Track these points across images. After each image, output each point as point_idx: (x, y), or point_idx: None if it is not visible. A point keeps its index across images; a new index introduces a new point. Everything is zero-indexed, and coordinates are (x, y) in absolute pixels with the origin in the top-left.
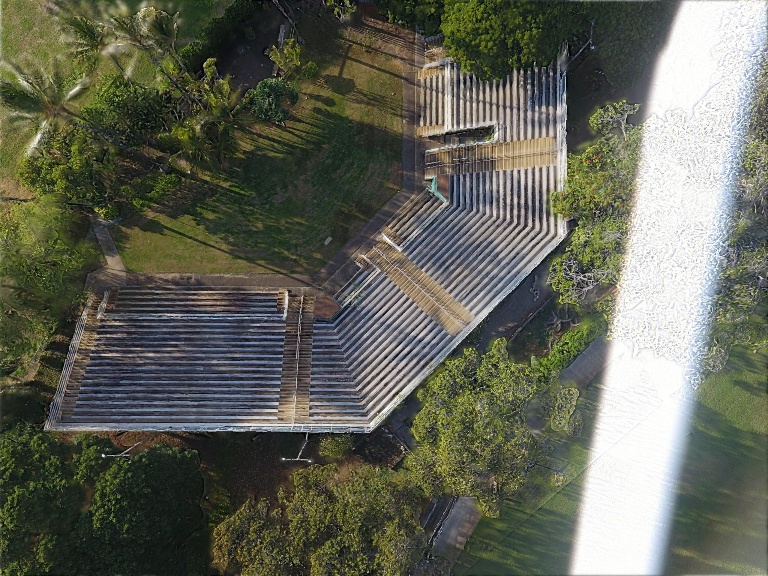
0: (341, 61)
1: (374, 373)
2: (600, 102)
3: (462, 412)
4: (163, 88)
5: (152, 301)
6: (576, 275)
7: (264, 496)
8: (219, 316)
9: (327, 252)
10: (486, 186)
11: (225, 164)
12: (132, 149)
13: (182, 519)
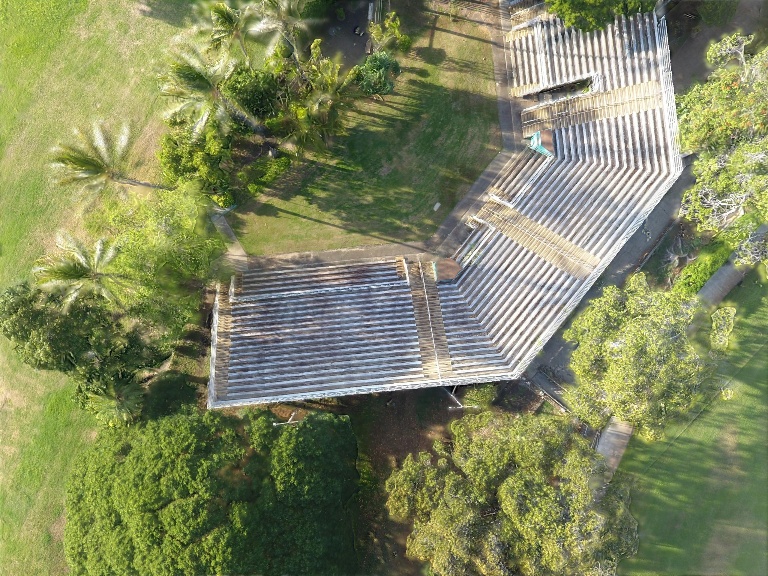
0: (430, 32)
1: (507, 324)
2: (683, 46)
3: (633, 338)
4: (277, 72)
5: (277, 281)
6: (714, 202)
7: (405, 457)
8: (345, 288)
9: (437, 217)
10: (591, 136)
11: (330, 143)
12: (238, 138)
13: None
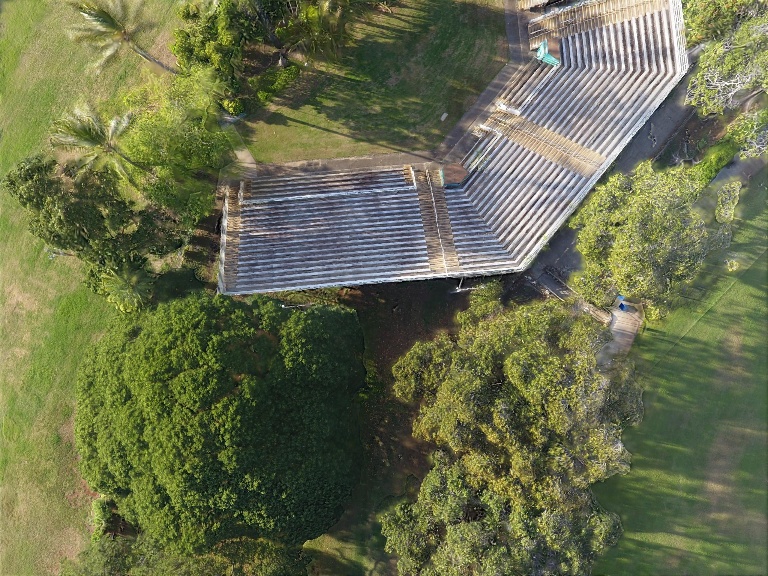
0: None
1: (514, 223)
2: None
3: (639, 206)
4: None
5: (285, 187)
6: (719, 84)
7: None
8: None
9: (444, 127)
10: (597, 42)
11: (339, 54)
12: (249, 48)
13: (352, 371)
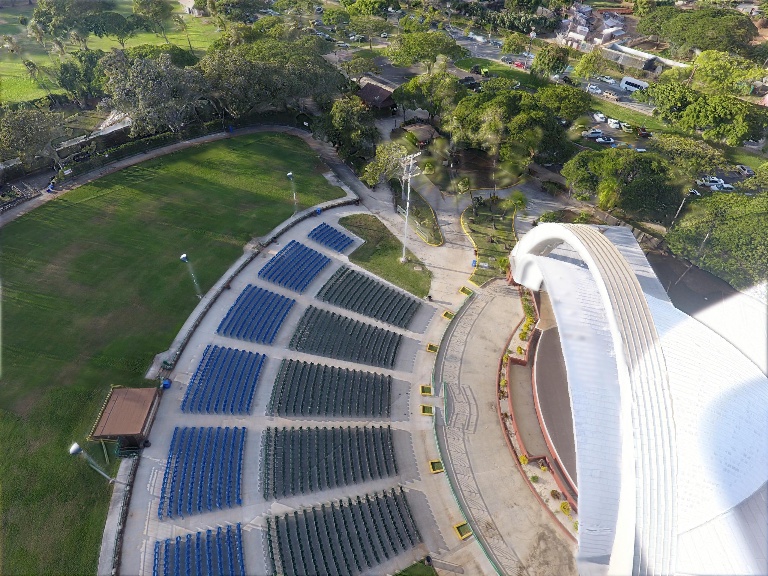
0: None
1: None
2: None
3: None
4: None
5: None
6: None
7: None
8: None
9: None
10: None
11: None
12: None
13: None
